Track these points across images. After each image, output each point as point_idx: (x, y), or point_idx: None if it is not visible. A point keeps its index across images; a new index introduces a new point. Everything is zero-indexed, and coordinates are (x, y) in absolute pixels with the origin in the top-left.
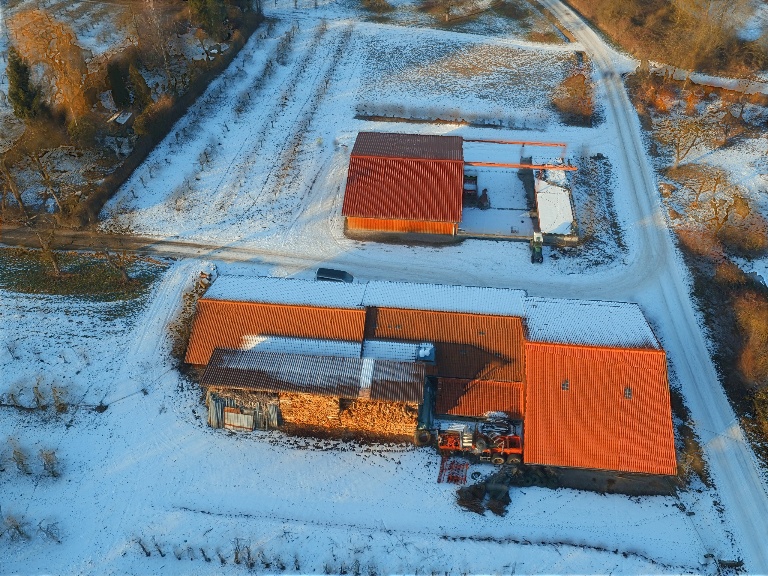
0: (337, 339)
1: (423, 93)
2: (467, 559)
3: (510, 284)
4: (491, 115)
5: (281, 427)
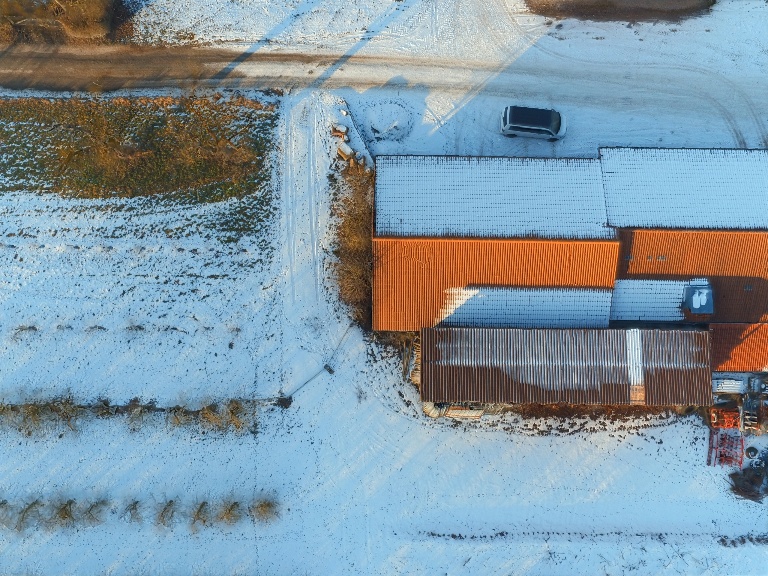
0: (578, 286)
1: None
2: (749, 566)
3: None
4: None
5: (514, 407)
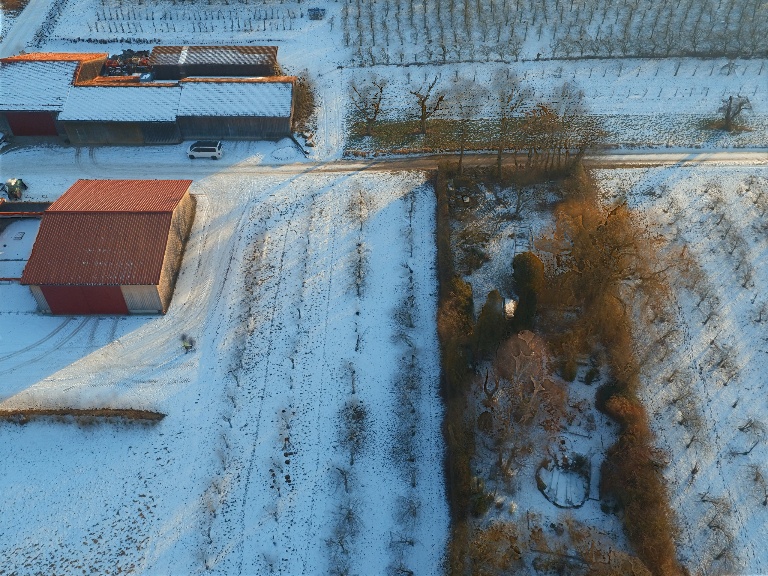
0: None
1: (9, 567)
2: None
3: (59, 170)
4: None
5: None
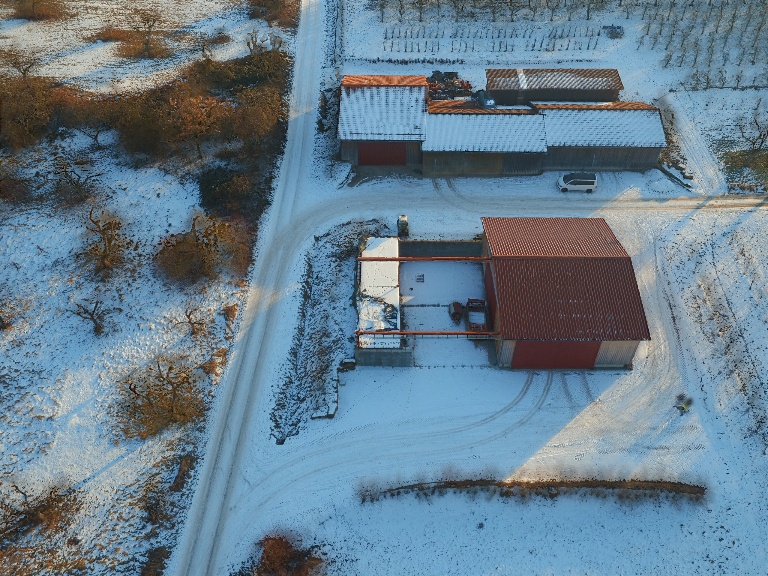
0: None
1: None
2: None
3: (427, 204)
4: (457, 572)
5: None
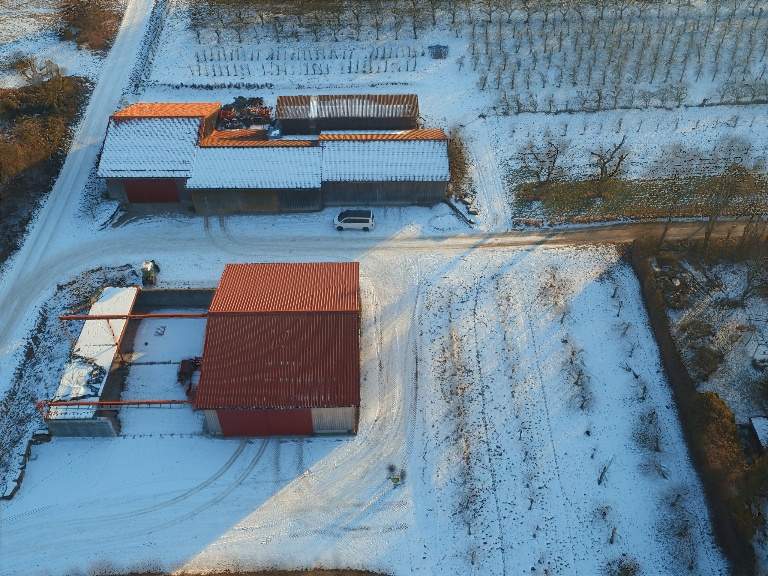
0: None
1: None
2: None
3: (190, 246)
4: None
5: None
